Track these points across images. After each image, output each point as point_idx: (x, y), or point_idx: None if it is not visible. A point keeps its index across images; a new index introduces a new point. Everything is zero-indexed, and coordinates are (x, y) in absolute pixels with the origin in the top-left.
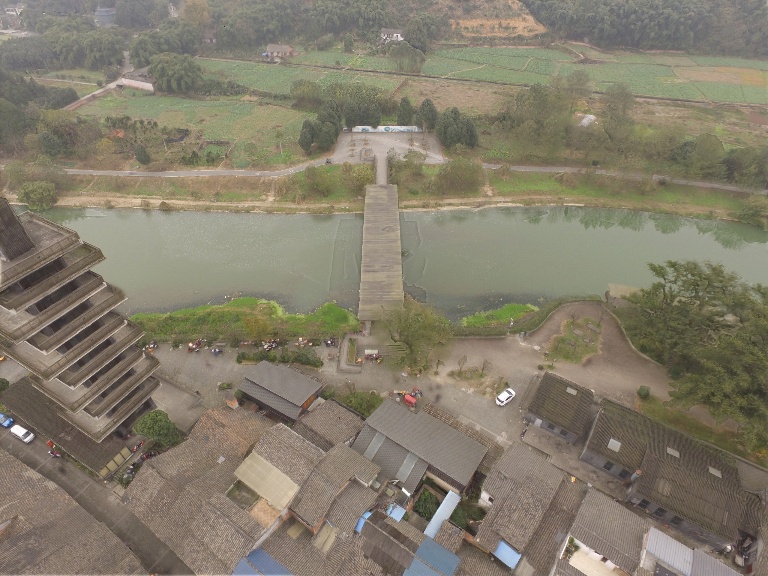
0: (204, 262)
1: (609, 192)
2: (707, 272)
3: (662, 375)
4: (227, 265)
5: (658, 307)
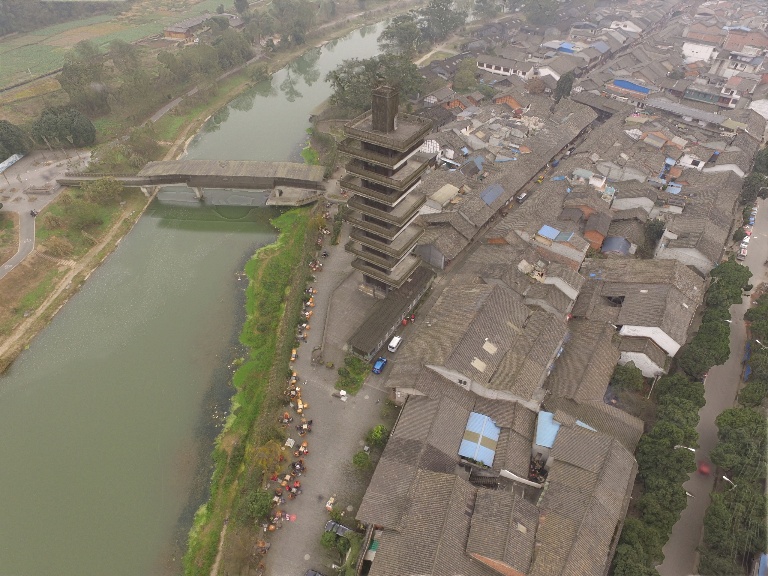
0: (170, 304)
1: (205, 103)
2: (348, 64)
3: None
4: (187, 284)
5: None
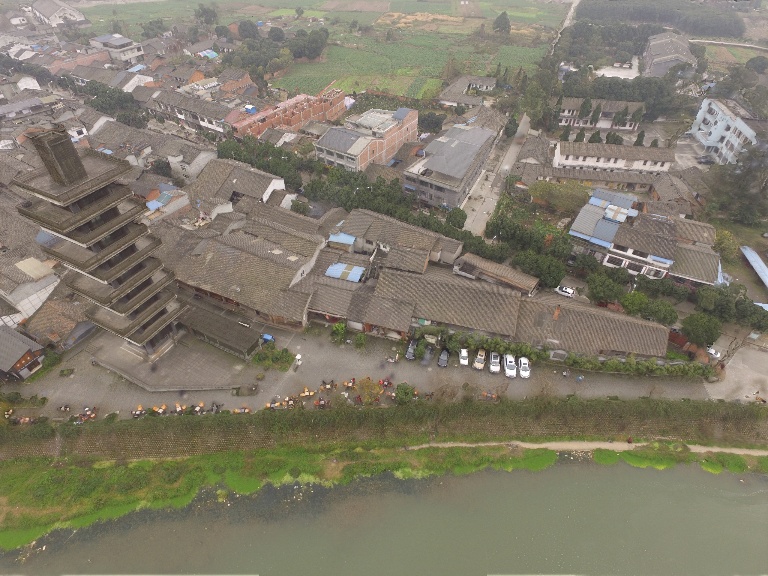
0: None
1: None
2: None
3: None
4: None
5: None
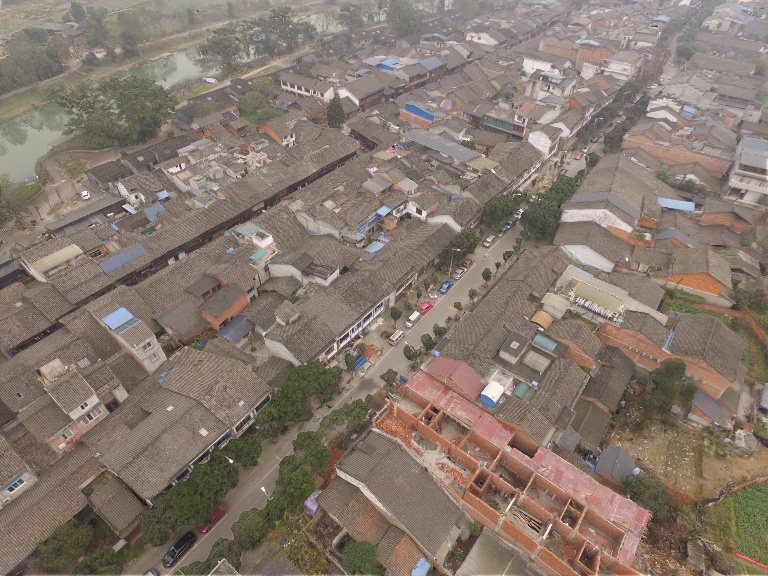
0: None
1: None
2: (79, 89)
3: (120, 149)
4: None
5: (82, 122)
